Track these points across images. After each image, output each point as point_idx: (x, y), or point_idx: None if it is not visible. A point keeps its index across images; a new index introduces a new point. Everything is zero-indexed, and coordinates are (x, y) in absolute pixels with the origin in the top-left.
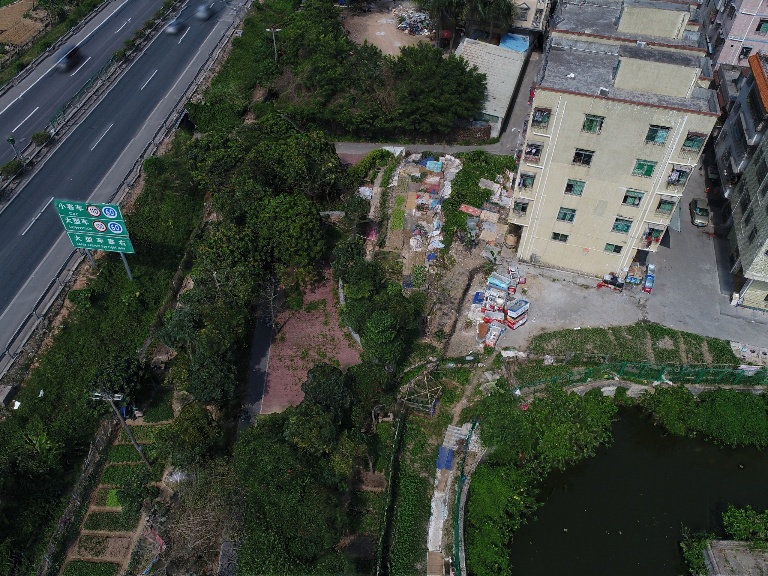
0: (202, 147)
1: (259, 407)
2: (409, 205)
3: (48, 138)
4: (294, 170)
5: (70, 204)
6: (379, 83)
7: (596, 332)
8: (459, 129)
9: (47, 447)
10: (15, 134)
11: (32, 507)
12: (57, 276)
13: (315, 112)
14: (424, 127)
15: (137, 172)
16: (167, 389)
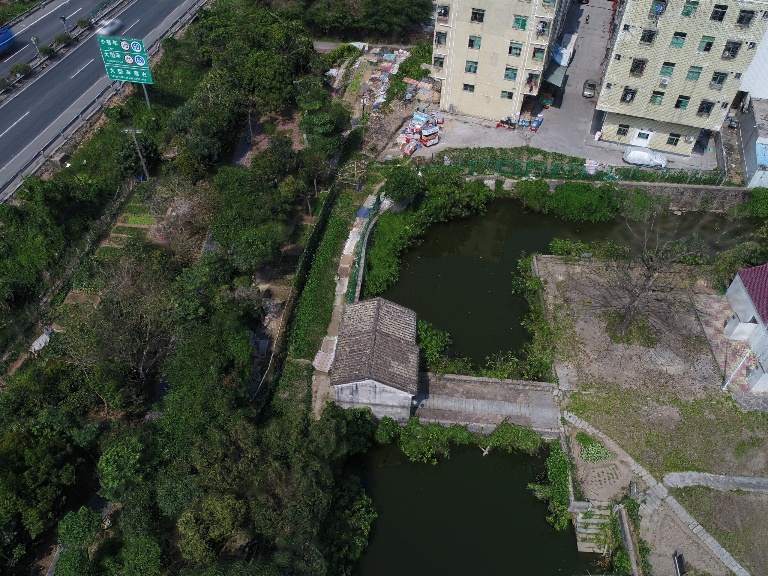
0: (207, 27)
1: None
2: None
3: (90, 23)
4: (274, 41)
5: (109, 40)
6: None
7: (487, 149)
8: (412, 32)
9: (89, 182)
10: None
11: (78, 218)
12: (96, 98)
13: (297, 13)
14: (383, 27)
15: (157, 48)
16: None
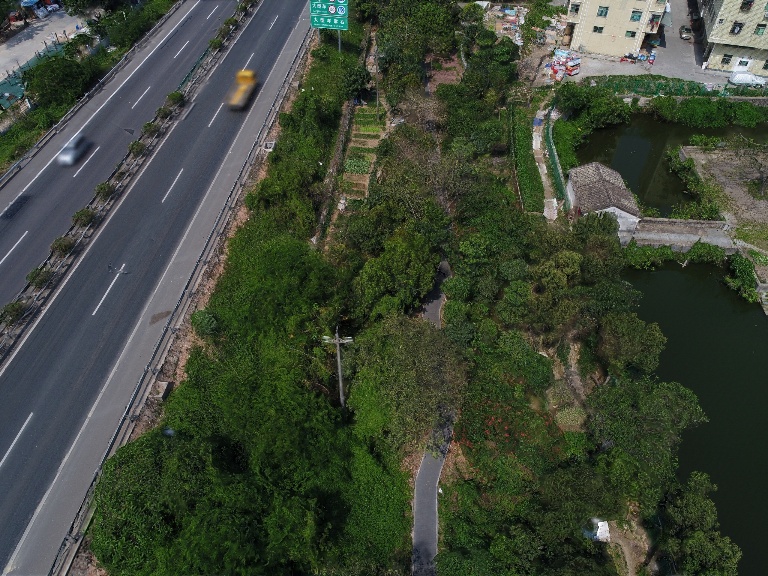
0: None
1: None
2: (498, 28)
3: None
4: None
5: None
6: None
7: (620, 76)
8: None
9: (330, 100)
10: None
11: (326, 127)
12: None
13: None
14: None
15: None
16: None
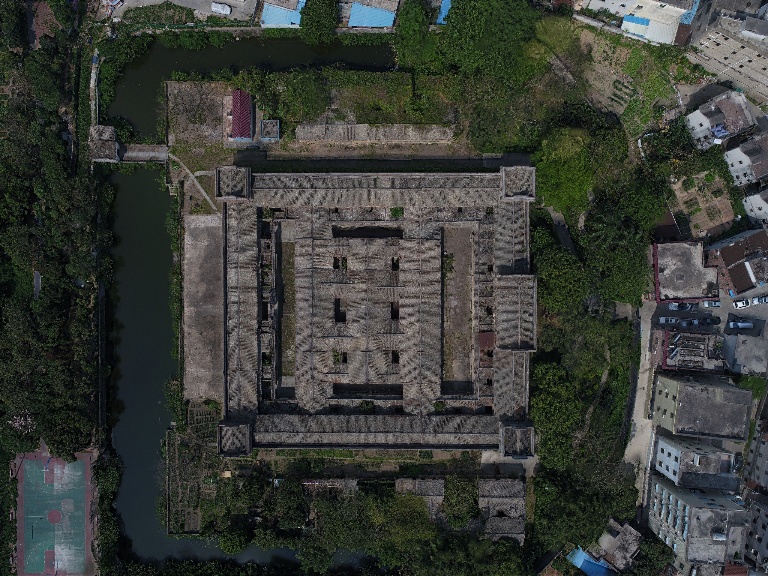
0: None
1: (35, 45)
2: None
3: None
4: None
5: None
6: None
7: (146, 9)
8: None
9: None
10: None
11: None
12: None
13: None
14: None
15: None
16: None
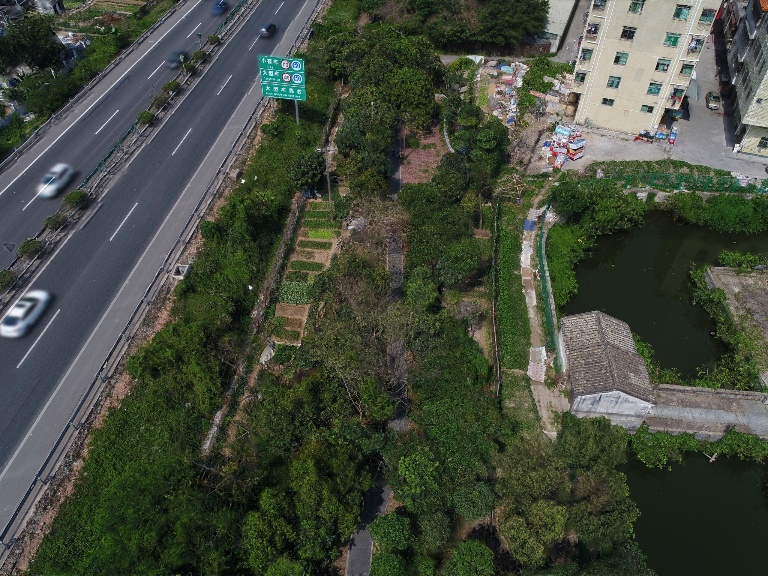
0: (338, 43)
1: None
2: (491, 91)
3: (218, 39)
4: (410, 56)
5: (270, 59)
6: (465, 7)
7: (633, 162)
8: (526, 45)
9: (272, 198)
10: (190, 39)
11: (264, 233)
12: (252, 115)
13: (416, 27)
14: (500, 40)
15: None
16: (334, 185)
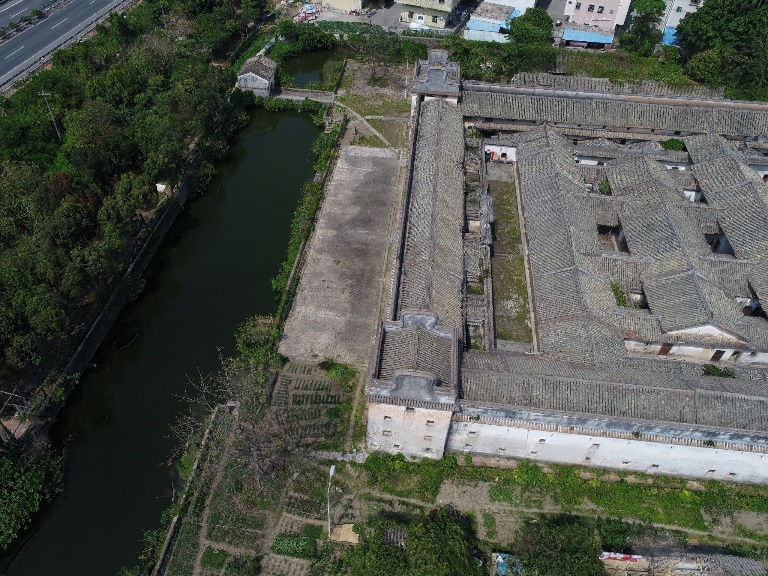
0: None
1: None
2: None
3: None
4: None
5: None
6: None
7: (339, 21)
8: None
9: (136, 21)
10: None
11: None
12: None
13: None
14: None
15: None
16: None
